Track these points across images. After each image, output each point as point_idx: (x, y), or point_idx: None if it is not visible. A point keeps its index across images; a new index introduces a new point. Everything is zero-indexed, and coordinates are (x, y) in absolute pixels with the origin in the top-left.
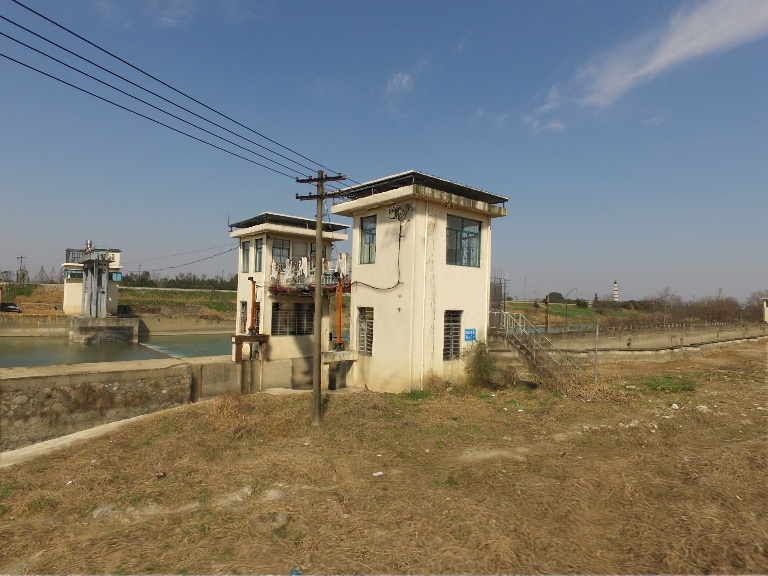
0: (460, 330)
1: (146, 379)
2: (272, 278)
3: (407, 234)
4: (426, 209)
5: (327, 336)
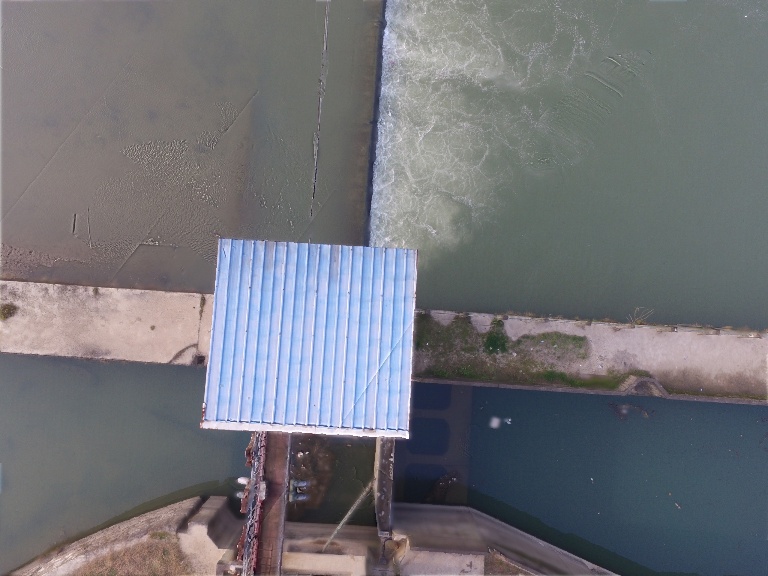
0: None
1: None
2: None
3: None
4: None
5: None
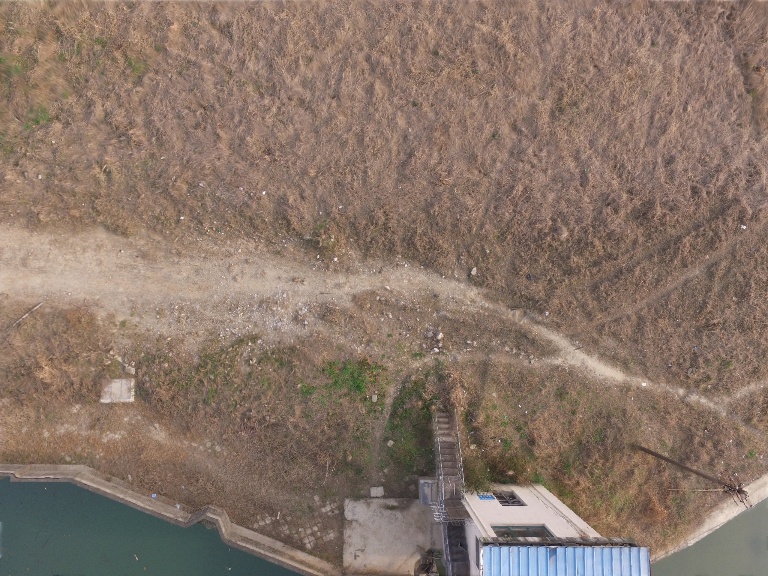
0: None
1: None
2: None
3: None
4: None
5: None
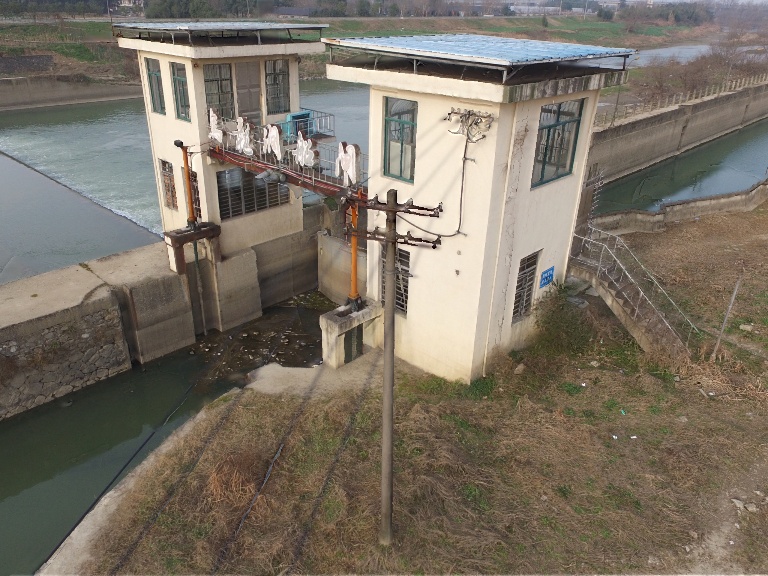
0: (535, 274)
1: (55, 326)
2: (213, 138)
3: (479, 159)
4: (514, 114)
5: (300, 204)
